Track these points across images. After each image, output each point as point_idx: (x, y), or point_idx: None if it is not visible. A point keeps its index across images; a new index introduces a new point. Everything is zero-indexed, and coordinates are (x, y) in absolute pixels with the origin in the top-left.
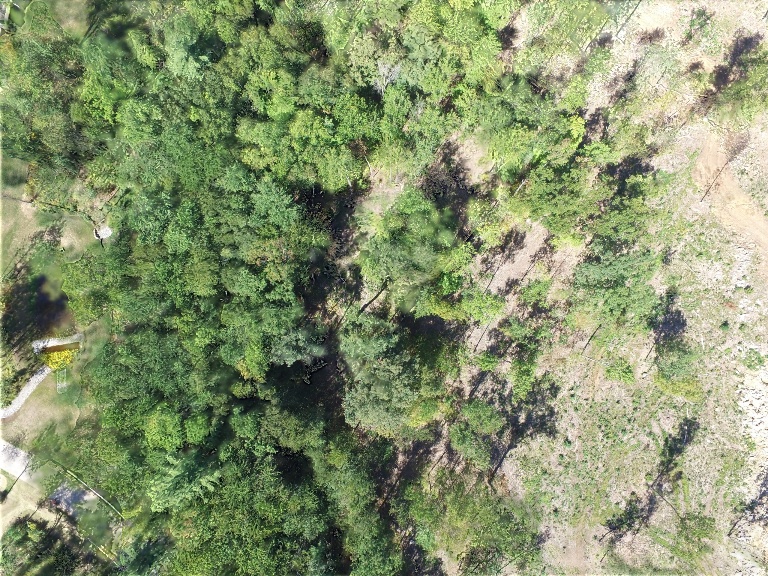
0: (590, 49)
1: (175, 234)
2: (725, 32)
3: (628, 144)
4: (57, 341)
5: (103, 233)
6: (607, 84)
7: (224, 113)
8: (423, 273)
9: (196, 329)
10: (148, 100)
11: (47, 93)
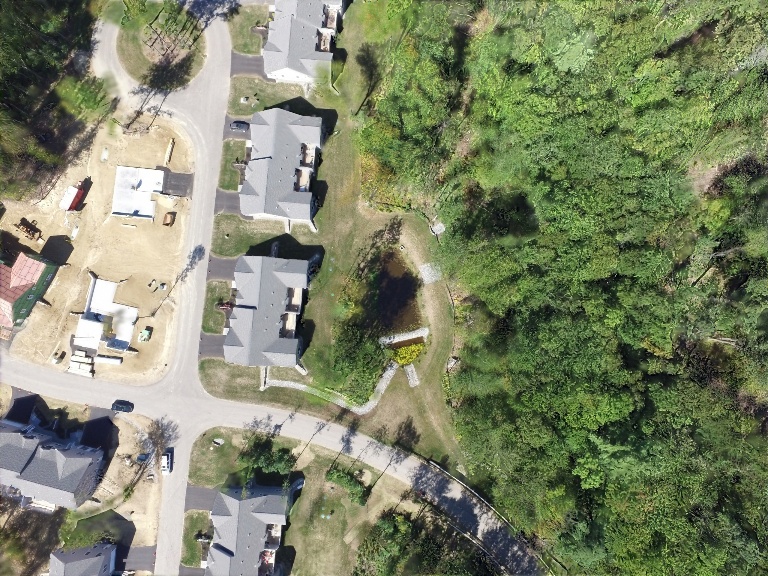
0: None
1: (583, 221)
2: None
3: None
4: (402, 337)
5: (437, 229)
6: None
7: (608, 103)
8: (756, 248)
9: (606, 311)
10: (543, 94)
11: (442, 92)
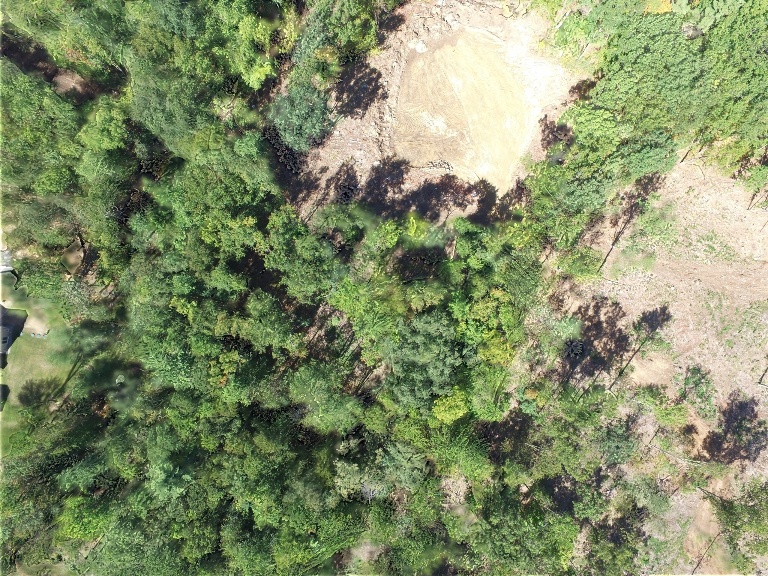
0: (583, 400)
1: None
2: (720, 393)
3: (620, 507)
4: None
5: None
6: (599, 439)
7: (208, 530)
8: None
9: None
10: (130, 525)
11: (27, 514)
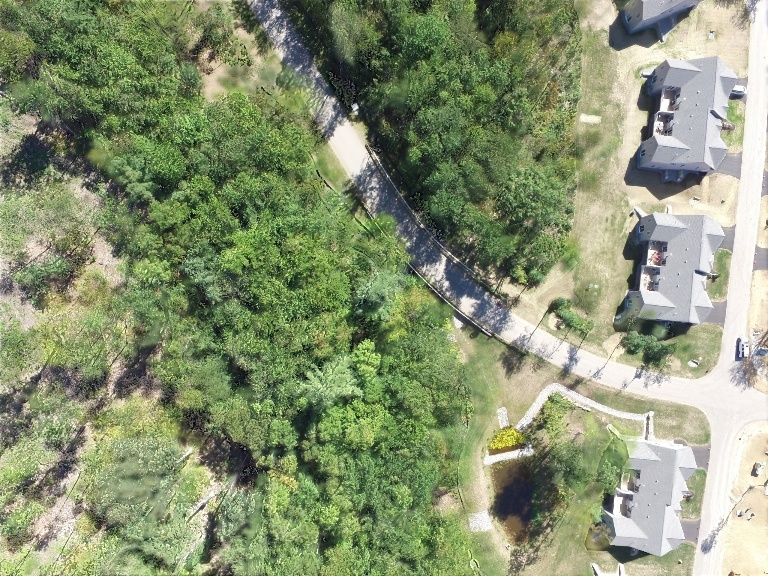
0: None
1: None
2: None
3: None
4: (510, 456)
5: (471, 564)
6: None
7: None
8: (136, 553)
9: None
10: None
11: None
